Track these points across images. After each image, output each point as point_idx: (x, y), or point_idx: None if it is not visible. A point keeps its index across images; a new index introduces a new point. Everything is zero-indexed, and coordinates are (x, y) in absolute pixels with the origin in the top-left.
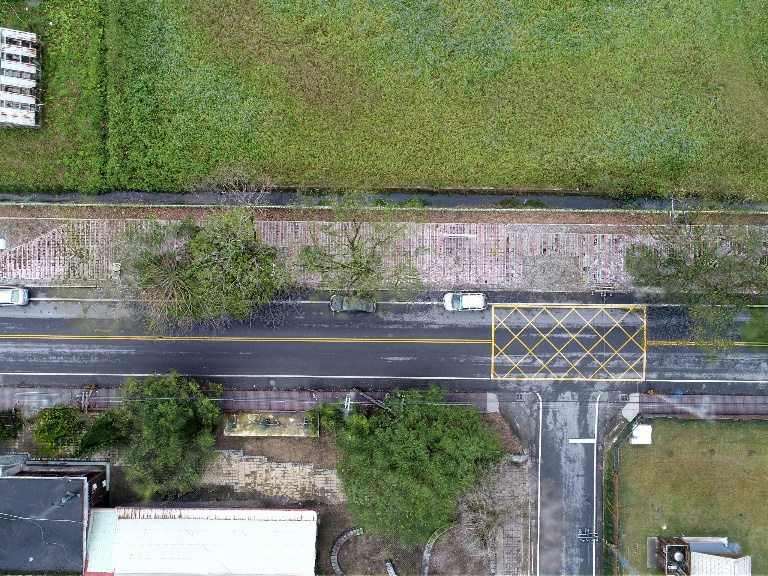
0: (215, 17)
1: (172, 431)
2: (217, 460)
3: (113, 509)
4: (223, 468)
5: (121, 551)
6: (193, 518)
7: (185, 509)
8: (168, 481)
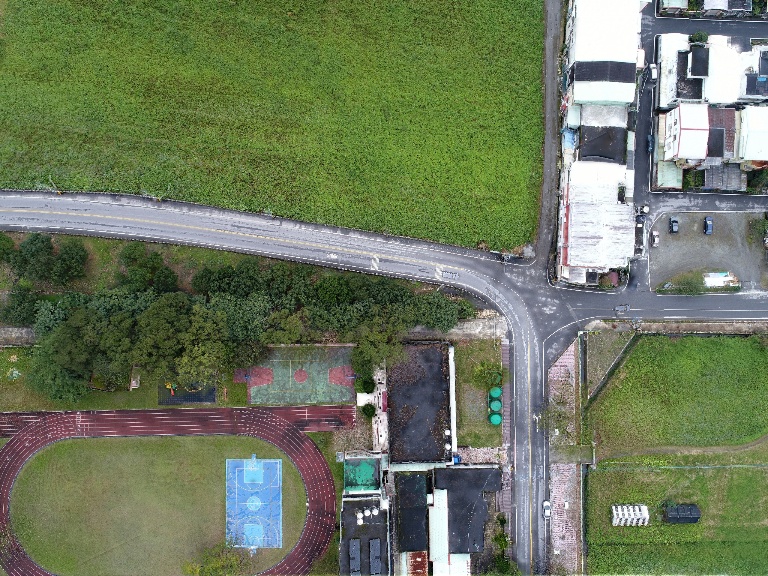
0: None
1: None
2: None
3: None
4: None
5: (457, 565)
6: None
7: None
8: (476, 570)
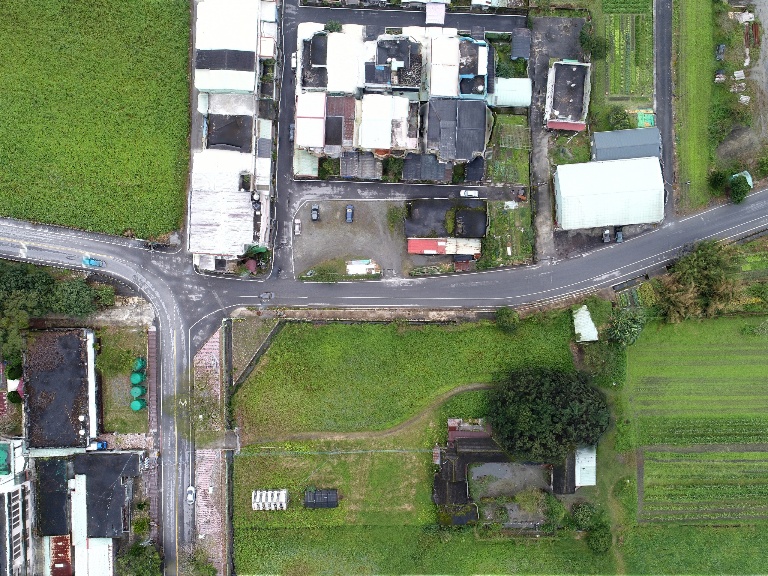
0: (298, 571)
1: (139, 573)
2: (132, 572)
3: (112, 542)
4: (129, 575)
5: (96, 549)
6: (109, 572)
7: (112, 569)
8: None
